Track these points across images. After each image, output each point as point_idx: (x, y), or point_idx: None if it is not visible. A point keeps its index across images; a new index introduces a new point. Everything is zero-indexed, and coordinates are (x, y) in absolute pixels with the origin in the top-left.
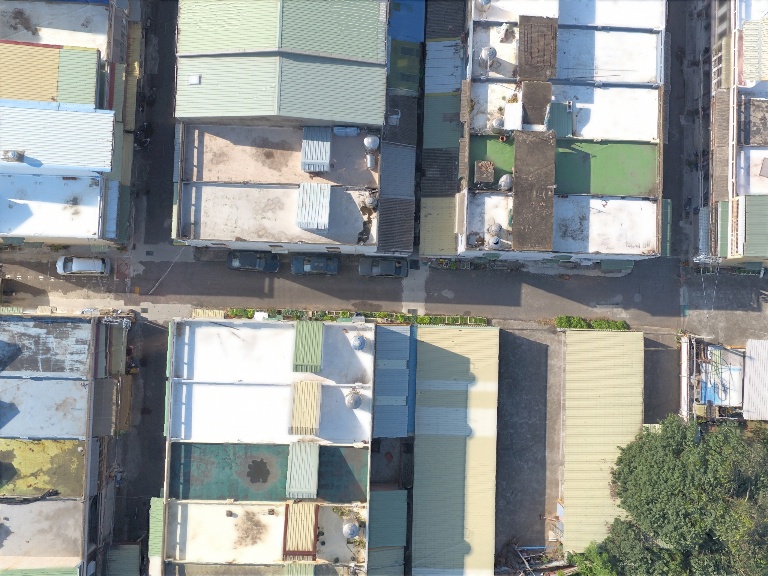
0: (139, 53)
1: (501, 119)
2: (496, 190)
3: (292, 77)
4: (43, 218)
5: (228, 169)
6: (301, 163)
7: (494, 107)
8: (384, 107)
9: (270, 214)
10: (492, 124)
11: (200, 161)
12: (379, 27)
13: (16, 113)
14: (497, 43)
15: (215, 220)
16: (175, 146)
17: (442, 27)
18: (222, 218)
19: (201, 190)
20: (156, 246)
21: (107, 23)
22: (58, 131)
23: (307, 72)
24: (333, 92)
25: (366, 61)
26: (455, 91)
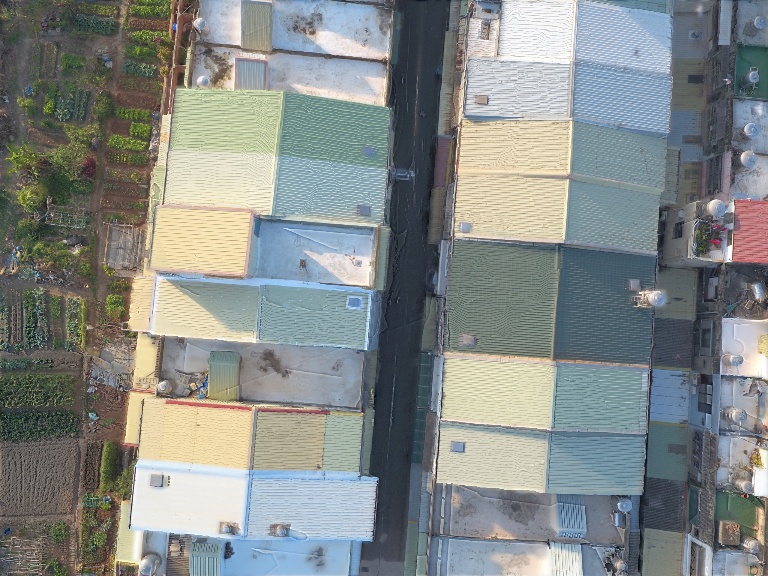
0: (374, 379)
1: (750, 484)
2: (738, 548)
3: (560, 453)
4: (288, 569)
5: (475, 521)
6: (559, 531)
7: (736, 461)
8: (643, 477)
9: (516, 569)
10: (741, 487)
11: (447, 512)
12: (641, 397)
13: (283, 484)
14: (740, 396)
15: (461, 574)
16: (421, 495)
17: (670, 355)
18: (468, 572)
19: (448, 543)
20: (372, 562)
21: (359, 368)
22: (323, 501)
23: (574, 447)
24: (597, 465)
25: (629, 433)
26: (683, 423)
